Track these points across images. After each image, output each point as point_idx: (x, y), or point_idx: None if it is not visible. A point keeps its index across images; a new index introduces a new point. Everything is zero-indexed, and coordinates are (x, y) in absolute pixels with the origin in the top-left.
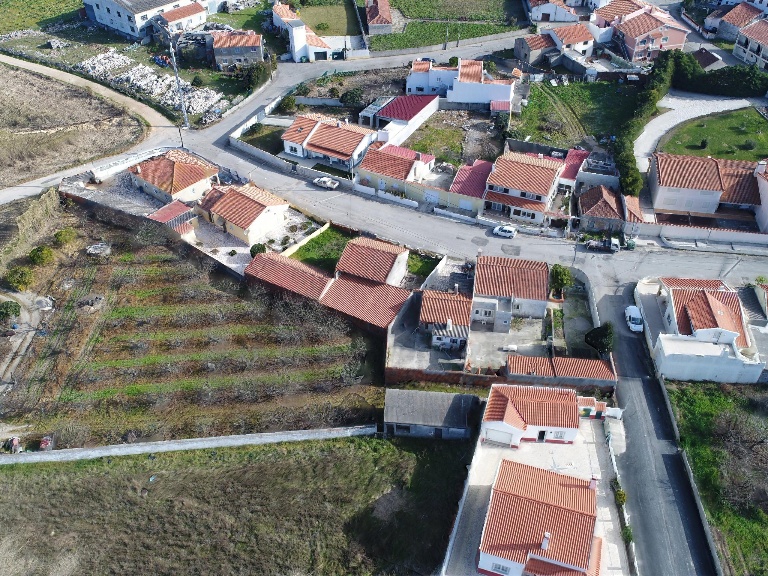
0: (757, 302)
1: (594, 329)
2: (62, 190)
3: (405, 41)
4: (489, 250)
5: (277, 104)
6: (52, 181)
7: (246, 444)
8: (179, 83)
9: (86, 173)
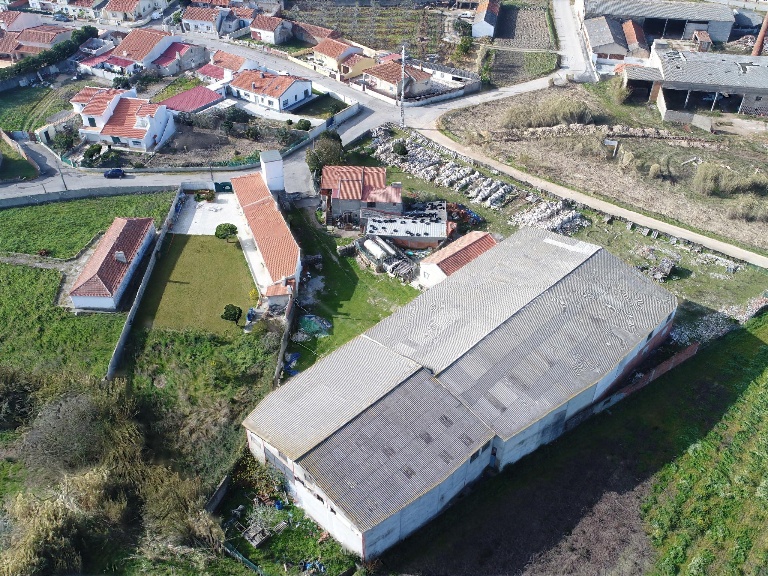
0: (101, 4)
1: (186, 0)
2: (476, 74)
3: (114, 213)
4: (201, 42)
5: (314, 134)
6: (496, 94)
7: (341, 4)
8: (428, 171)
9: (467, 84)
